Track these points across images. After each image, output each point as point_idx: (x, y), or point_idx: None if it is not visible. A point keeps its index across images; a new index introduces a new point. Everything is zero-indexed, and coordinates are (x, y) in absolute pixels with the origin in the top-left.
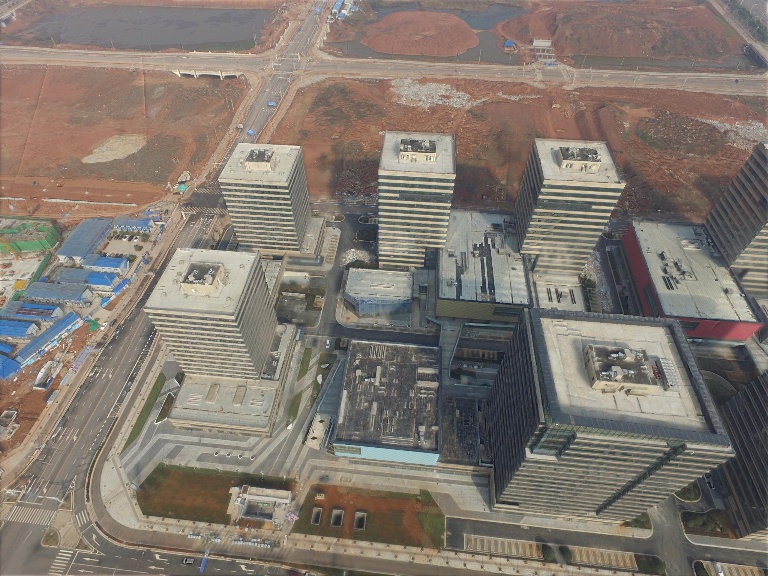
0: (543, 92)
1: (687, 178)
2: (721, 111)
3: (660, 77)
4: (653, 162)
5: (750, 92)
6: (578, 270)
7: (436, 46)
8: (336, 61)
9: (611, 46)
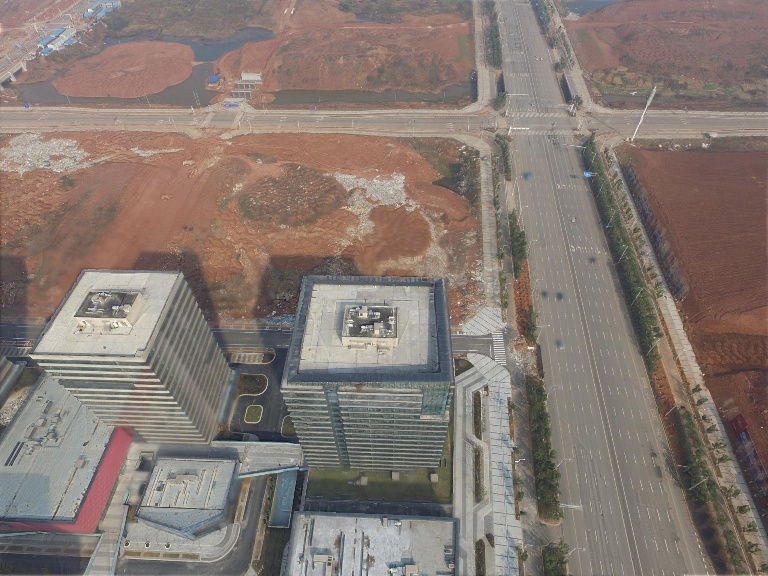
0: (189, 144)
1: (257, 259)
2: (371, 161)
3: (344, 117)
4: (229, 239)
5: (431, 132)
6: None
7: (126, 86)
8: None
9: (322, 78)
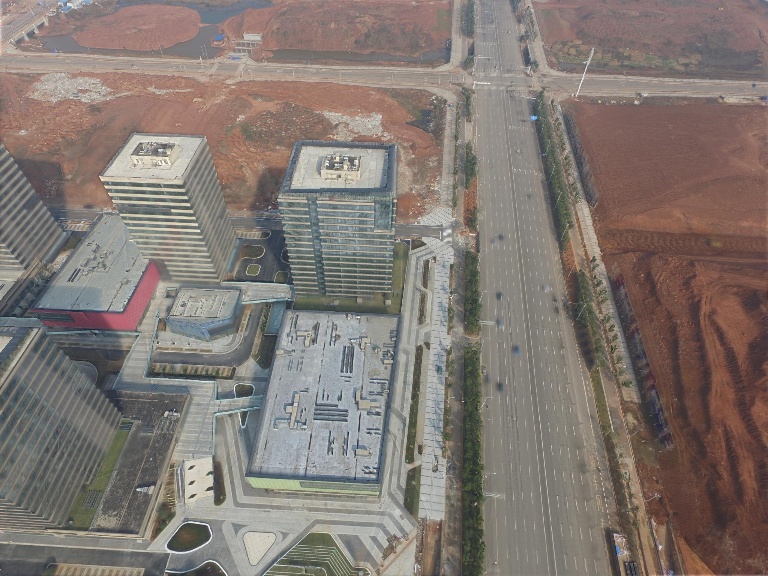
0: (198, 86)
1: (257, 170)
2: (355, 104)
3: (333, 71)
4: (234, 155)
5: (407, 85)
6: (17, 265)
7: (140, 40)
8: (17, 55)
9: (315, 40)
